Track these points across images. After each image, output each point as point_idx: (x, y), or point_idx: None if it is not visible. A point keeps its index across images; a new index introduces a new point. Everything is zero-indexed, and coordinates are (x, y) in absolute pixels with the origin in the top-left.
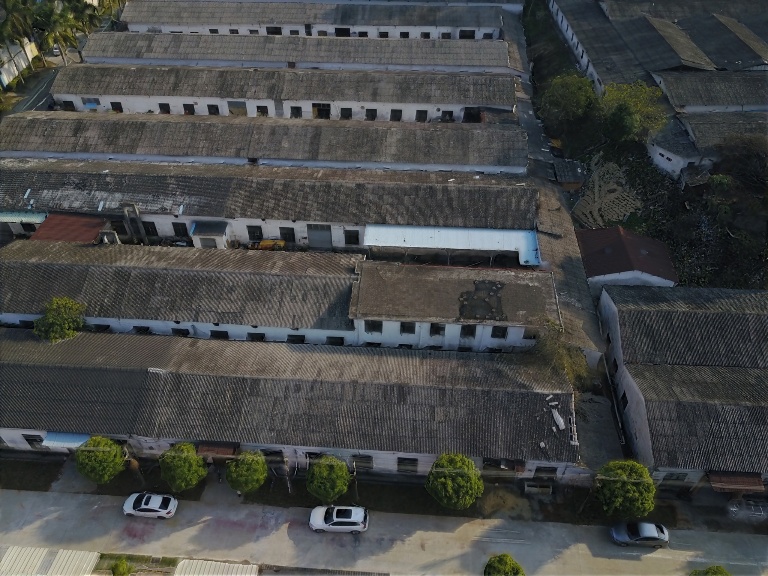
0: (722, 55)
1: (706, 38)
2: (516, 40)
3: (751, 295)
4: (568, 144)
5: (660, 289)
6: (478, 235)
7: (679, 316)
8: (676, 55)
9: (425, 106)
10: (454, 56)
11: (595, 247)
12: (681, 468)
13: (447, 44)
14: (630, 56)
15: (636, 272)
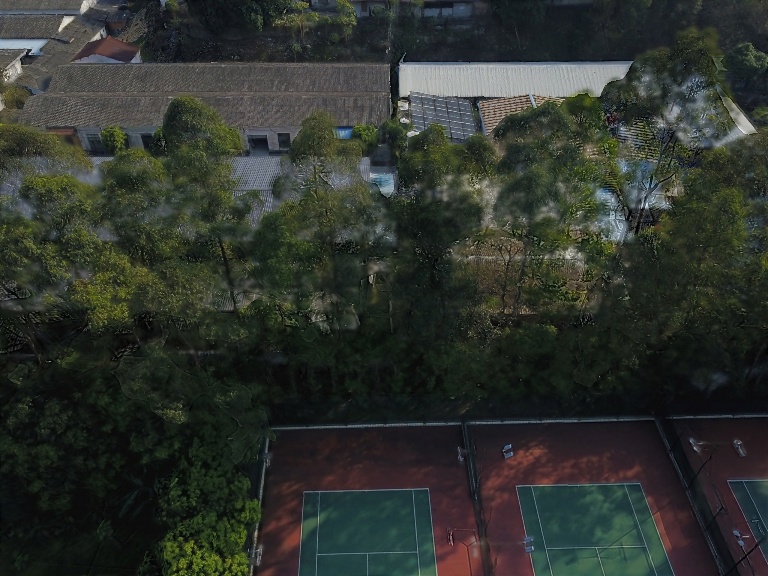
0: None
1: None
2: None
3: (158, 63)
4: (136, 4)
5: None
6: (13, 42)
7: (92, 68)
8: None
9: None
10: None
11: None
12: (31, 127)
13: None
14: None
15: (98, 56)
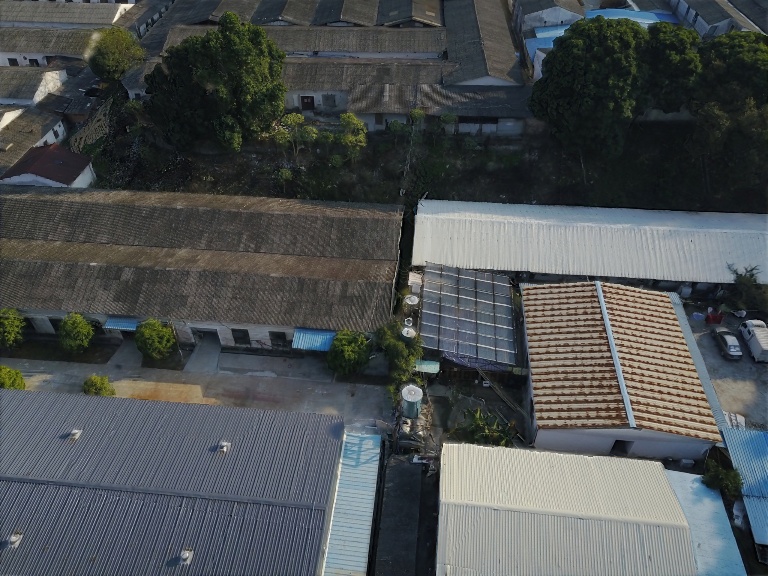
0: (262, 14)
1: (269, 1)
2: (152, 5)
3: (101, 192)
4: (109, 86)
5: (38, 187)
6: None
7: (11, 202)
8: (211, 12)
9: (13, 55)
10: (70, 15)
11: (27, 158)
12: None
13: (69, 5)
14: (188, 14)
15: (31, 175)
